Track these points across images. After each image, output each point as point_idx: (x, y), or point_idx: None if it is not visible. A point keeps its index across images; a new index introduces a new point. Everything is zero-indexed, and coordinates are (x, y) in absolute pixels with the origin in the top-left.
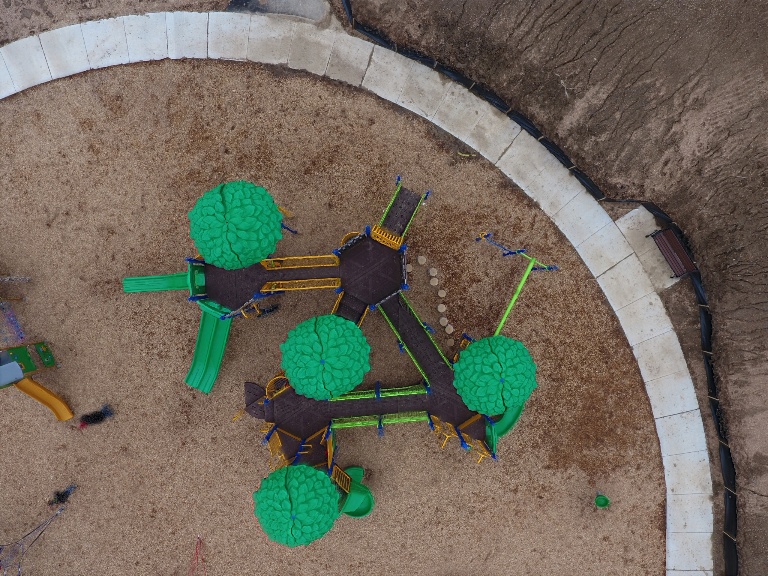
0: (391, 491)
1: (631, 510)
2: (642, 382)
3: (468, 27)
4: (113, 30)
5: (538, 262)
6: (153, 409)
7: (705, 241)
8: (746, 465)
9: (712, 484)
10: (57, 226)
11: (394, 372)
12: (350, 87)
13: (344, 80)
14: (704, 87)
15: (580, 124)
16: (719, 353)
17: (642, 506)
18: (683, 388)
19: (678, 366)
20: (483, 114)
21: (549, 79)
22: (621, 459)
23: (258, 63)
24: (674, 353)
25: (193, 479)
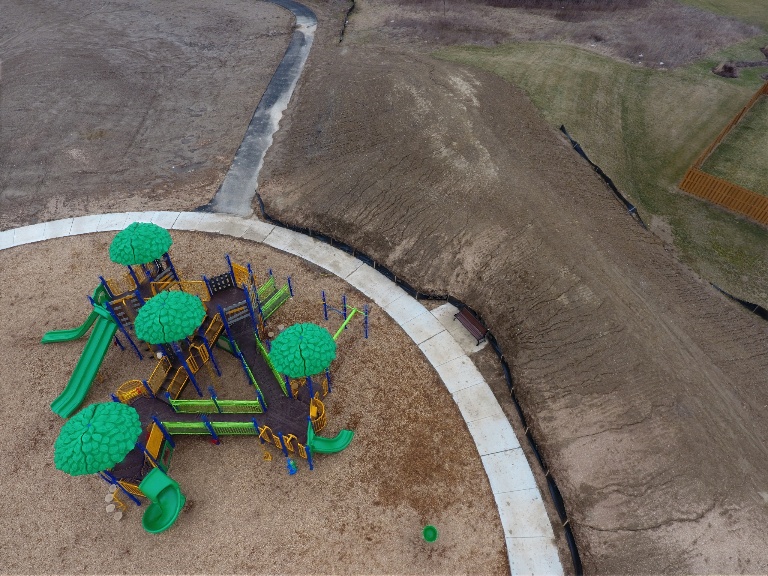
0: (208, 526)
1: (469, 557)
2: (464, 423)
3: (331, 216)
4: (120, 217)
5: (359, 311)
6: (7, 436)
7: (496, 321)
8: (576, 498)
9: (551, 526)
10: (18, 305)
11: (241, 409)
12: (255, 243)
13: (252, 239)
14: (469, 235)
15: (400, 258)
16: (524, 395)
17: (481, 552)
18: (502, 428)
19: (494, 410)
20: (339, 256)
21: (379, 238)
22: (452, 496)
23: (201, 231)
24: (489, 399)
25: (4, 507)
